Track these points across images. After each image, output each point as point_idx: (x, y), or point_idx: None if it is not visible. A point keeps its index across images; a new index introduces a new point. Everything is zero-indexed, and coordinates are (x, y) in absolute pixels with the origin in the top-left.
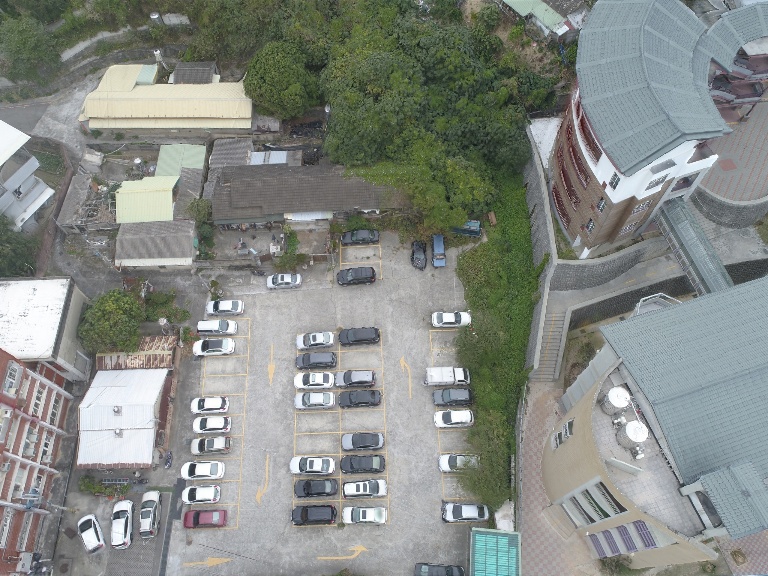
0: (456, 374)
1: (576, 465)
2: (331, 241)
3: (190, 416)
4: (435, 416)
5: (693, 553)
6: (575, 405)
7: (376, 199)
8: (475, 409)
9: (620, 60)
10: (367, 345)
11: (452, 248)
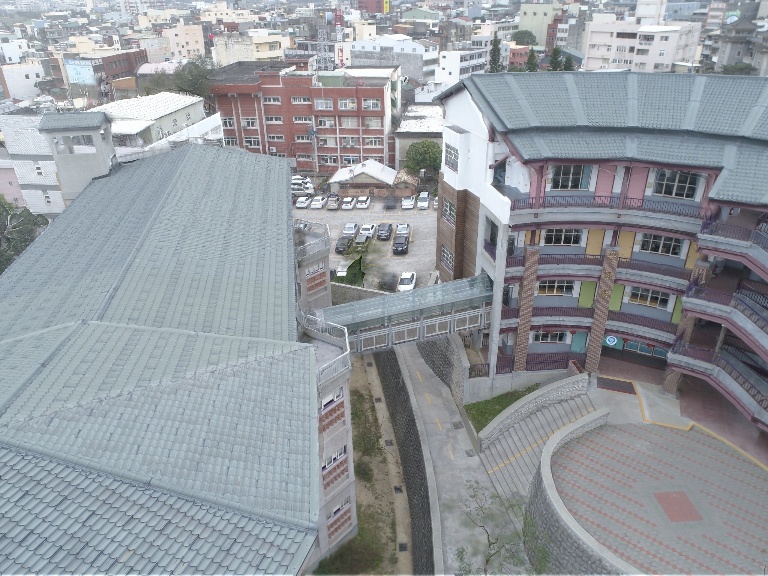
0: (344, 272)
1: None
2: None
3: None
4: None
5: None
6: None
7: None
8: None
9: None
10: None
11: None
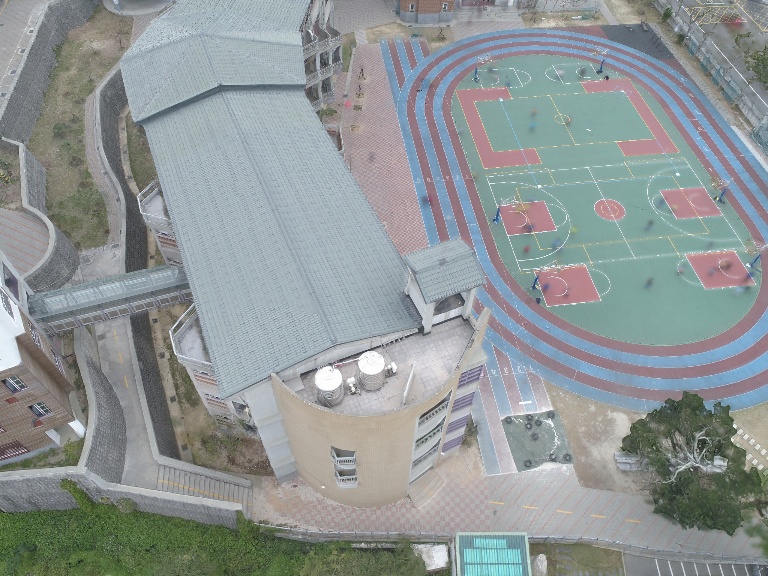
0: None
1: (392, 450)
2: None
3: None
4: None
5: None
6: (303, 453)
7: None
8: None
9: None
10: None
11: None
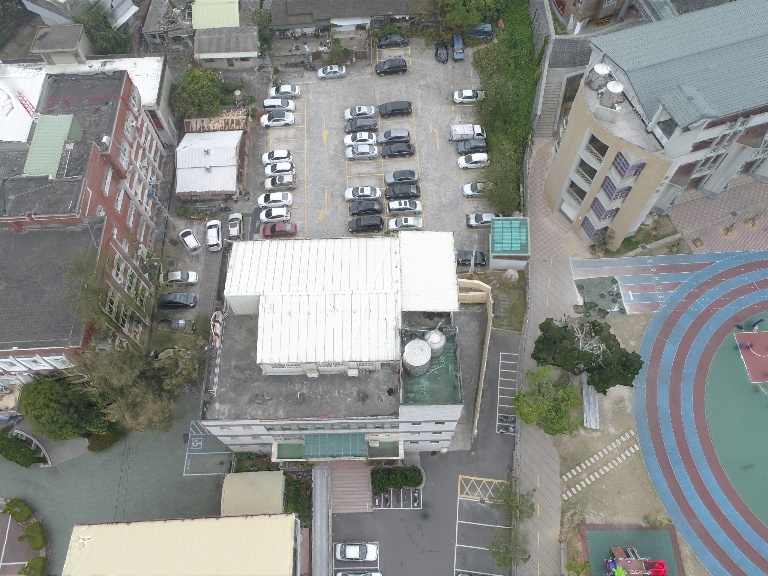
0: (475, 129)
1: (571, 142)
2: (370, 40)
3: (261, 167)
4: (459, 160)
5: (656, 169)
6: None
7: (406, 6)
8: (490, 156)
9: None
10: (402, 117)
11: (468, 48)
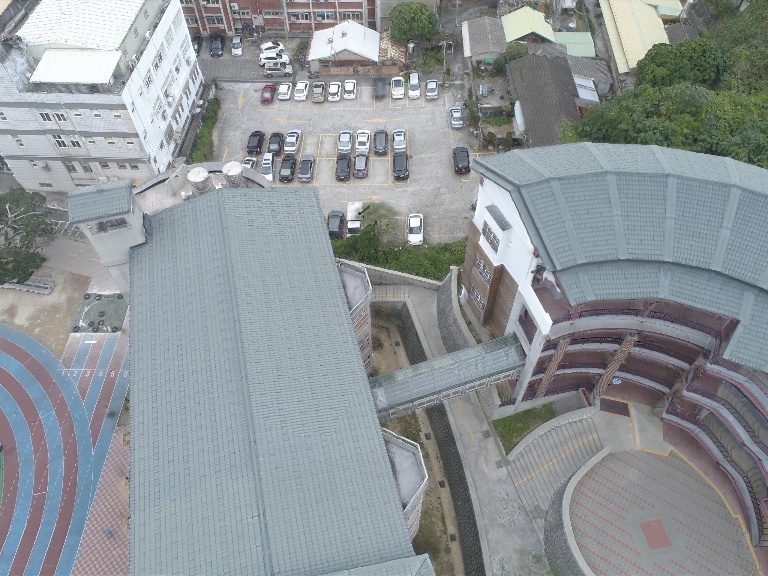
0: (354, 222)
1: None
2: None
3: None
4: None
5: None
6: None
7: None
8: None
9: (660, 163)
10: None
11: None
